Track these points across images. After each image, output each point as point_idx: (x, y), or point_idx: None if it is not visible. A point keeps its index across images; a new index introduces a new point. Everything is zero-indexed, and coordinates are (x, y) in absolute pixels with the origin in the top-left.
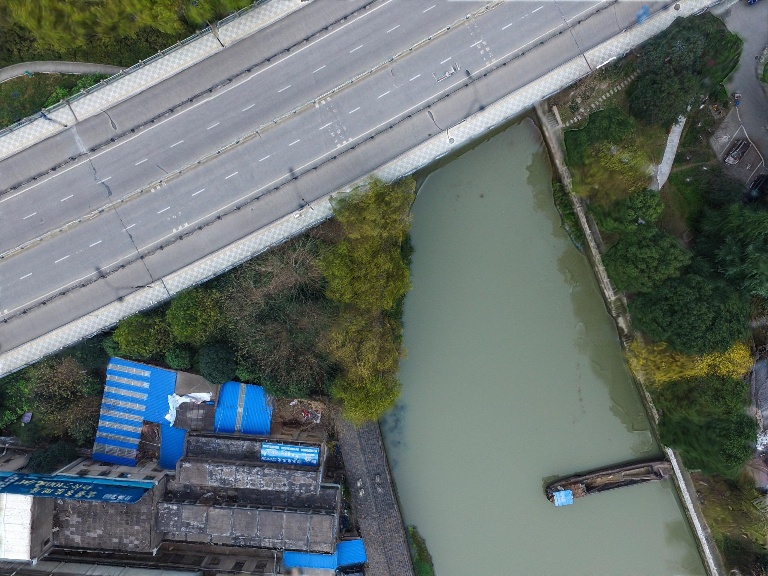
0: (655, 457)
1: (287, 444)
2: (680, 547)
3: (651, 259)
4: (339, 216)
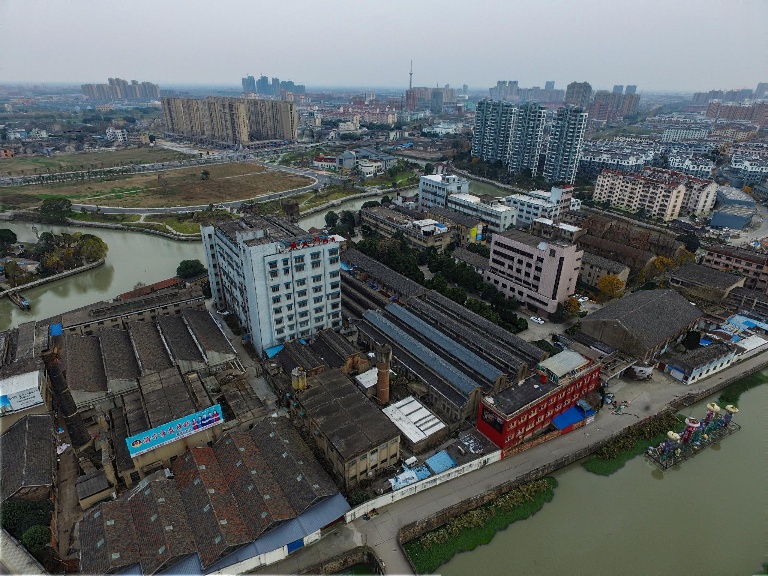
0: (7, 297)
1: None
2: (73, 293)
3: None
4: None
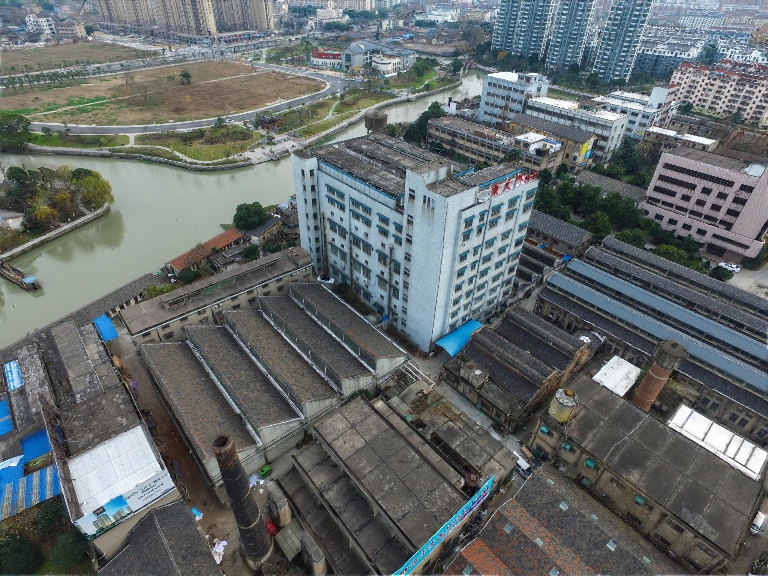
0: None
1: (6, 380)
2: (78, 254)
3: None
4: None
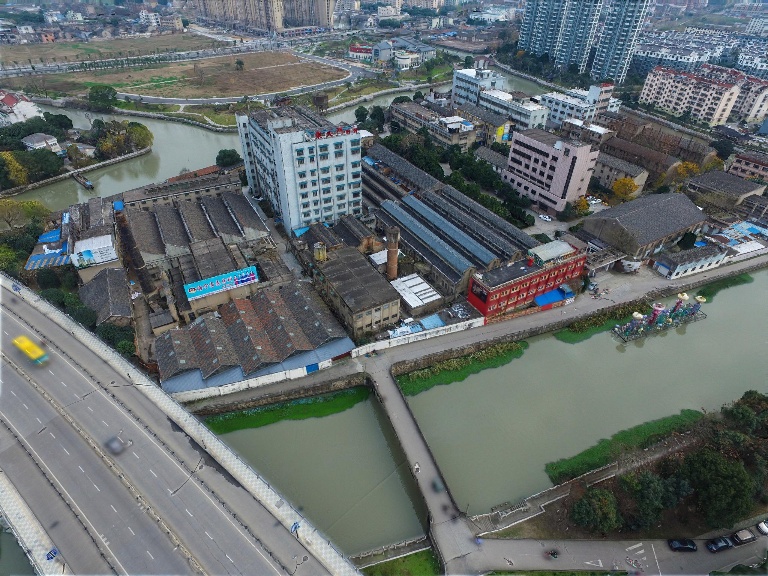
0: None
1: None
2: (127, 177)
3: None
4: None
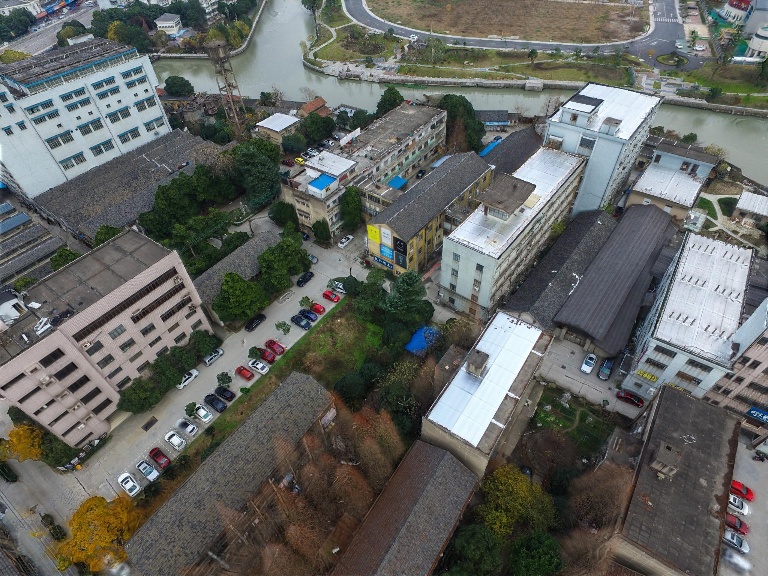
0: None
1: None
2: (202, 76)
3: (88, 31)
4: (2, 56)
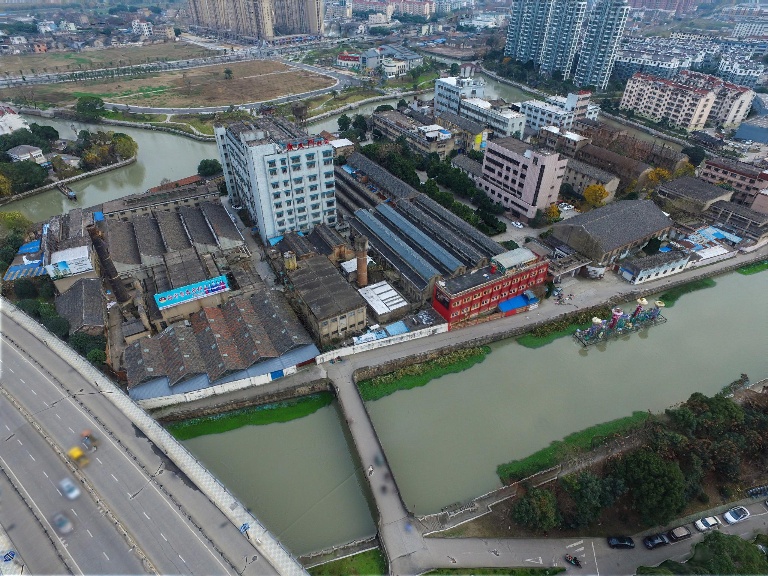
0: (57, 188)
1: None
2: (112, 187)
3: None
4: None
